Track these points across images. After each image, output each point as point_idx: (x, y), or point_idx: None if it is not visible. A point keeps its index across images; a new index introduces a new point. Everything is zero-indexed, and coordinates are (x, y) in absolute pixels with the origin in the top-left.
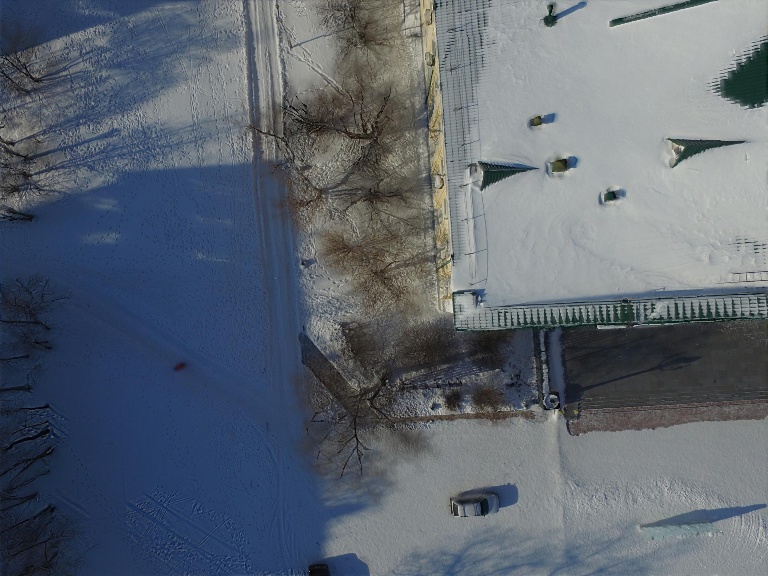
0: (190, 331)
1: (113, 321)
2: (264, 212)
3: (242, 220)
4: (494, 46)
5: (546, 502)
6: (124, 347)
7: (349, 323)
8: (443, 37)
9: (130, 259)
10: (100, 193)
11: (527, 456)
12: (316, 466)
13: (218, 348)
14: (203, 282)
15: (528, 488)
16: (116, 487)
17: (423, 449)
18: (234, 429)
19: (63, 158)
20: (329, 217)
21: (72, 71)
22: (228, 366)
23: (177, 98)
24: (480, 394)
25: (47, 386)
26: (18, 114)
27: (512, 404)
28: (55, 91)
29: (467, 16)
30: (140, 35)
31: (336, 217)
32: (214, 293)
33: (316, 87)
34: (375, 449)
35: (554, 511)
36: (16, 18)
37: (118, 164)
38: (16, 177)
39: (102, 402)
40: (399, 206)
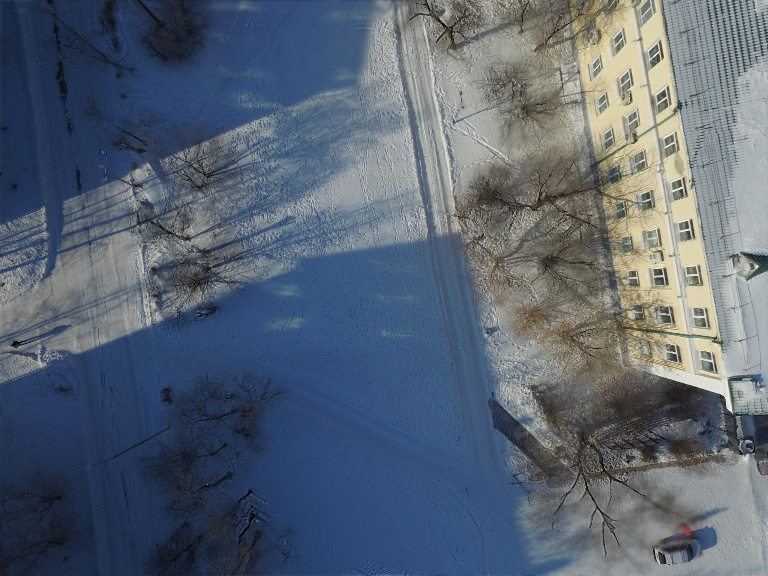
0: (383, 407)
1: (305, 403)
2: (443, 285)
3: (422, 295)
4: (746, 141)
5: (744, 542)
6: (320, 428)
7: (537, 386)
8: (691, 135)
9: (315, 342)
10: (281, 280)
11: (721, 499)
12: (518, 527)
13: (412, 421)
14: (390, 358)
15: (725, 530)
16: (326, 564)
17: (620, 501)
18: (434, 498)
19: (241, 249)
20: (507, 285)
21: (241, 164)
22: (423, 437)
23: (347, 182)
24: (673, 444)
25: (251, 473)
26: (191, 210)
27: (705, 451)
28: (226, 184)
29: (715, 113)
30: (305, 123)
31: (514, 284)
32: (402, 368)
33: (483, 160)
34: (573, 505)
35: (753, 550)
36: (180, 116)
37: (296, 251)
38: (196, 272)
39: (304, 483)
40: (574, 268)
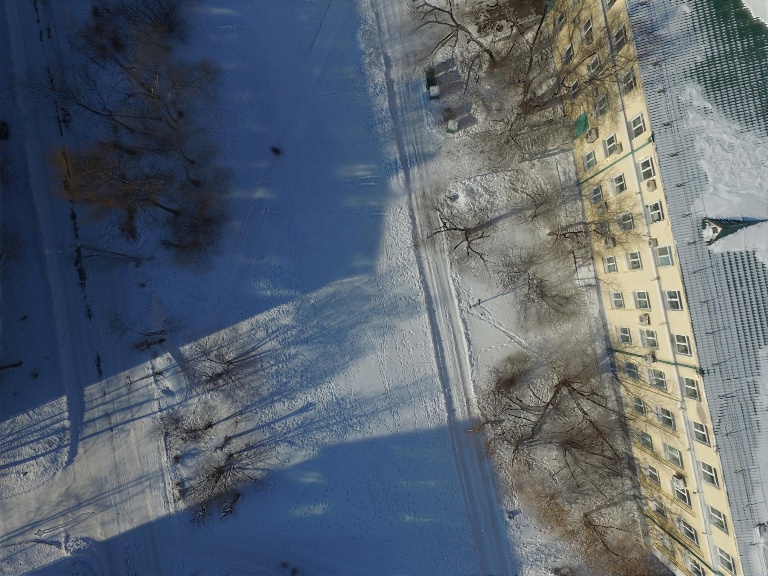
0: None
1: None
2: (464, 468)
3: (444, 479)
4: None
5: None
6: None
7: (560, 569)
8: (714, 402)
9: (339, 527)
10: (303, 467)
11: None
12: None
13: None
14: (414, 543)
15: None
16: None
17: None
18: None
19: (262, 436)
20: (528, 468)
21: (261, 351)
22: None
23: (367, 368)
24: None
25: None
26: (212, 397)
27: None
28: (246, 372)
29: (737, 383)
30: (323, 310)
31: (534, 467)
32: (426, 553)
33: (500, 344)
34: None
35: None
36: (199, 304)
37: (317, 437)
38: (219, 459)
39: None
40: (593, 449)
